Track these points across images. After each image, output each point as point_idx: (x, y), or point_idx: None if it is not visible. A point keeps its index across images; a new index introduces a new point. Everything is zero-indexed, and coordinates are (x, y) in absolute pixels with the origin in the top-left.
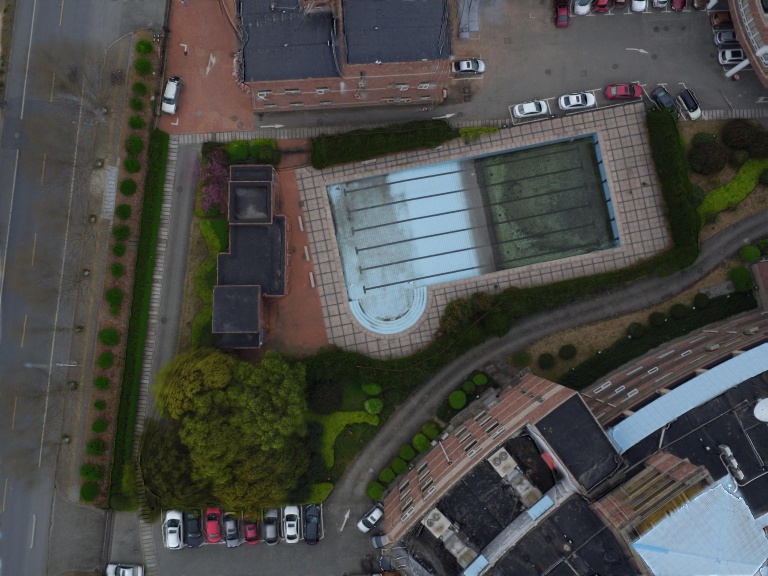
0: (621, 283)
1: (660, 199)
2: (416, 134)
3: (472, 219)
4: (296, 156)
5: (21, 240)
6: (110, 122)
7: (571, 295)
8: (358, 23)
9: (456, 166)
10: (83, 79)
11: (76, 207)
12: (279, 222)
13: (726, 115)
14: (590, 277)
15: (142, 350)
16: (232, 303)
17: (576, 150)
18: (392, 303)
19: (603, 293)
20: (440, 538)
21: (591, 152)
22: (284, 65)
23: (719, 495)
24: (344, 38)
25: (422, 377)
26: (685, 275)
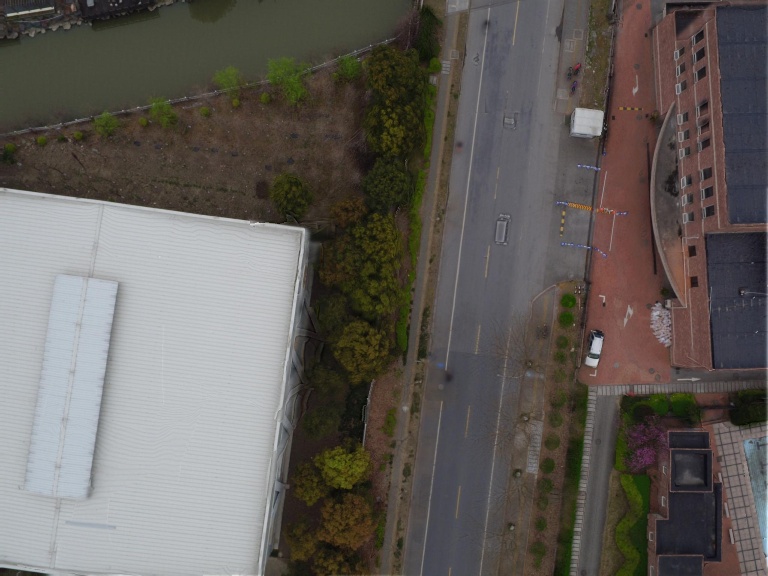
0: None
1: None
2: None
3: None
4: (713, 410)
5: (445, 493)
6: (534, 375)
7: None
8: None
9: None
10: (509, 333)
11: (500, 460)
12: (716, 488)
13: None
14: None
15: None
16: (677, 573)
17: None
18: None
19: None
20: None
21: None
22: (754, 351)
23: None
24: None
25: None
26: None
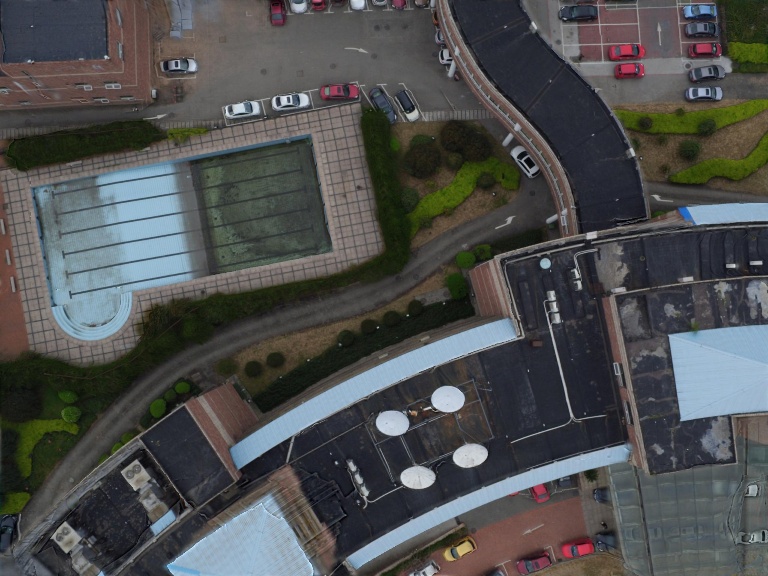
0: (333, 289)
1: (373, 203)
2: (113, 135)
3: (186, 223)
4: (2, 157)
5: None
6: None
7: (276, 301)
8: (14, 21)
9: (170, 168)
10: None
11: None
12: None
13: (447, 117)
14: (297, 283)
15: None
16: None
17: (296, 152)
18: (98, 309)
19: (314, 299)
20: (70, 553)
21: (309, 154)
22: None
23: (257, 515)
24: (1, 36)
25: (118, 385)
26: (400, 281)
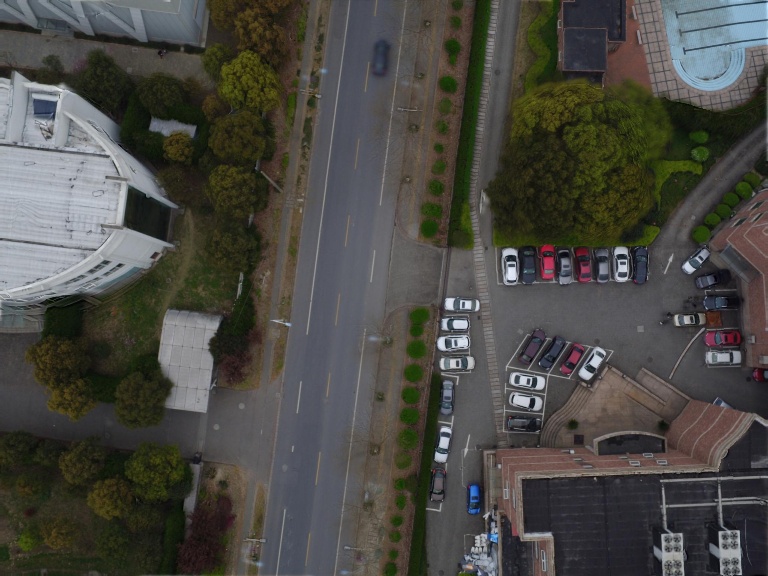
0: None
1: None
2: None
3: None
4: None
5: None
6: None
7: None
8: None
9: None
10: None
11: None
12: None
13: None
14: None
15: (478, 99)
16: (581, 44)
17: None
18: (710, 64)
19: None
20: None
21: None
22: None
23: None
24: None
25: (748, 126)
26: None
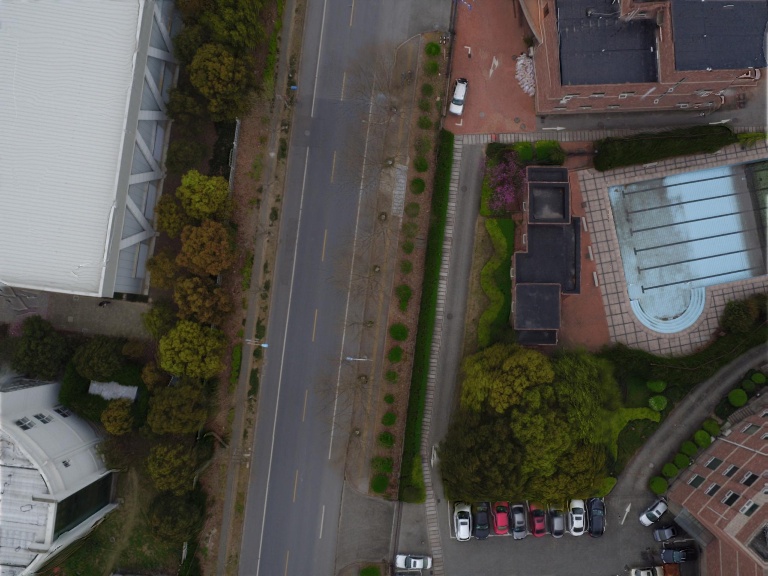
0: None
1: None
2: (704, 139)
3: (743, 222)
4: (578, 158)
5: (312, 236)
6: (399, 121)
7: None
8: (686, 31)
9: (728, 170)
10: (374, 79)
11: (365, 204)
12: (574, 222)
13: None
14: None
15: (429, 345)
16: (534, 301)
17: None
18: (669, 303)
19: None
20: None
21: None
22: (601, 70)
23: None
24: (672, 45)
25: (707, 375)
26: None
